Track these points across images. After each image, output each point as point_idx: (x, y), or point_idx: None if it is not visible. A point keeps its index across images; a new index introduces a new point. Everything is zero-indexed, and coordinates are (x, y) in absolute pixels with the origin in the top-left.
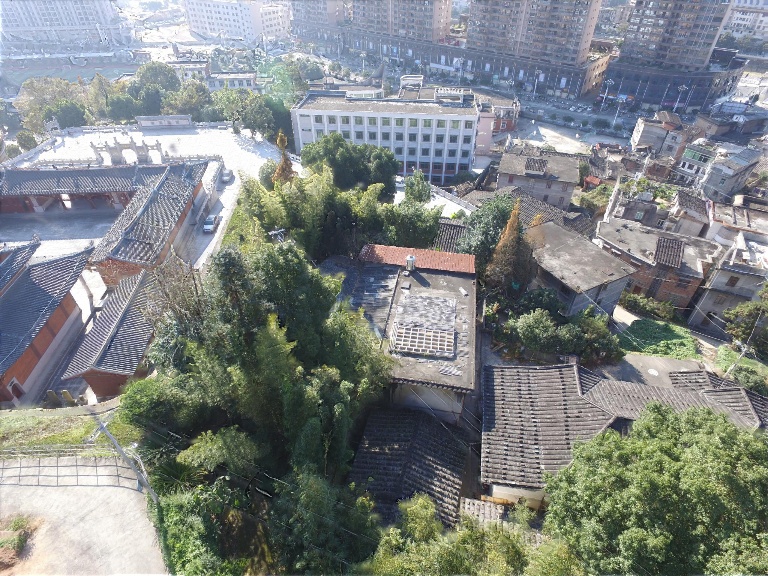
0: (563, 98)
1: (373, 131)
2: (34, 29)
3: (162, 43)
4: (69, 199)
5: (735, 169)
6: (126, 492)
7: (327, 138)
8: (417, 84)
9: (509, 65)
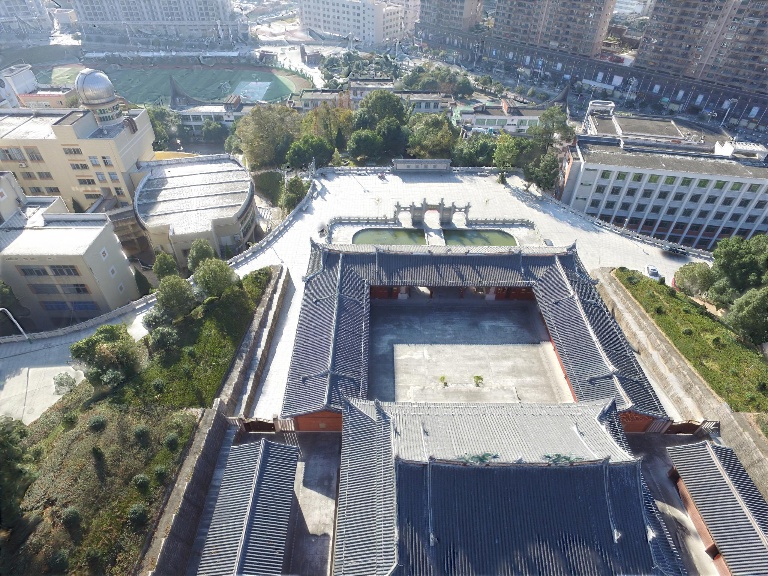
0: (750, 129)
1: (666, 190)
2: (154, 23)
3: (279, 42)
4: None
5: None
6: None
7: None
8: (604, 110)
9: (685, 88)
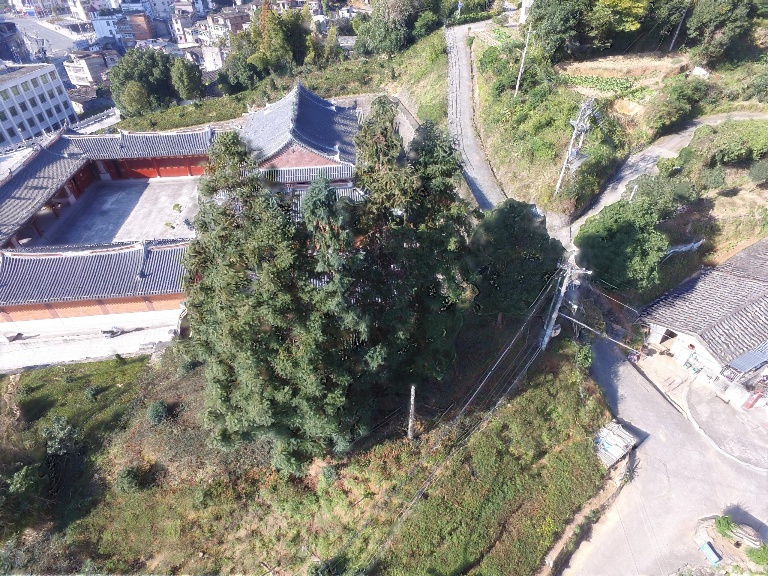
0: None
1: None
2: None
3: None
4: None
5: (182, 49)
6: None
7: (134, 53)
8: None
9: None
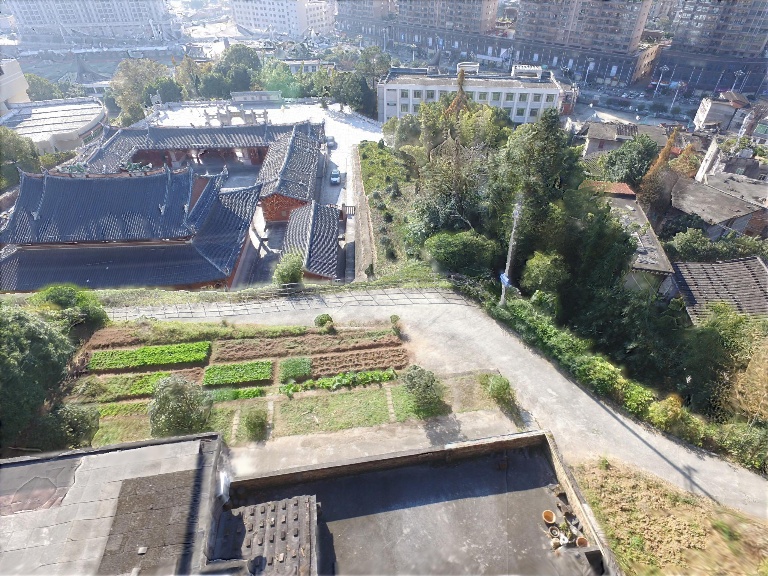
0: (613, 86)
1: None
2: (91, 25)
3: (210, 38)
4: (199, 157)
5: None
6: (459, 306)
7: (447, 97)
8: (472, 71)
9: (558, 54)
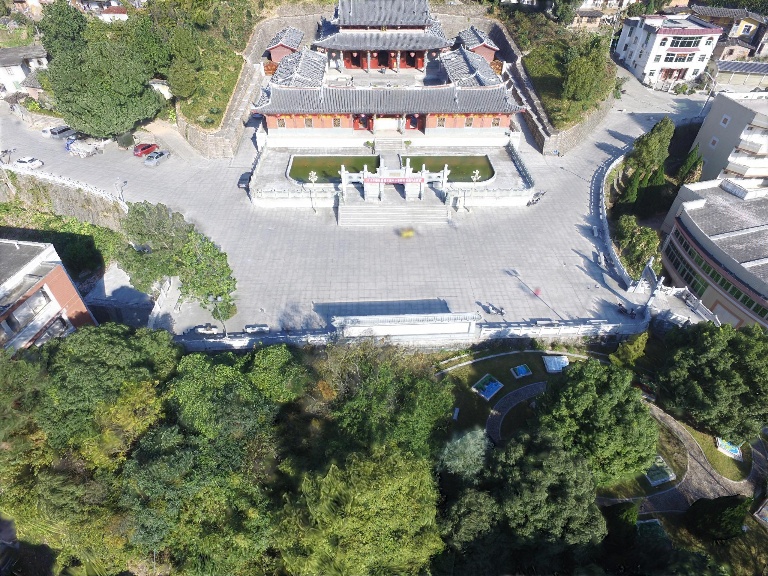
0: None
1: None
2: None
3: None
4: (410, 128)
5: None
6: None
7: None
8: None
9: None
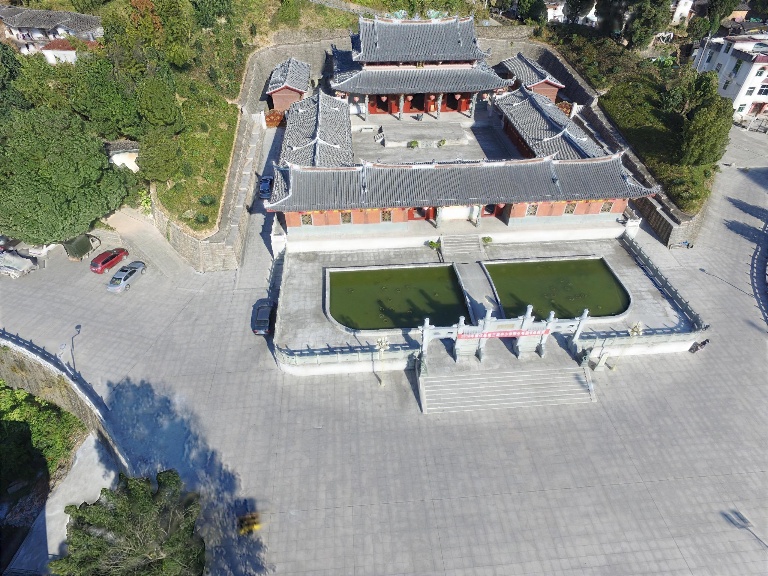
0: None
1: None
2: None
3: None
4: (484, 214)
5: None
6: None
7: None
8: None
9: None
